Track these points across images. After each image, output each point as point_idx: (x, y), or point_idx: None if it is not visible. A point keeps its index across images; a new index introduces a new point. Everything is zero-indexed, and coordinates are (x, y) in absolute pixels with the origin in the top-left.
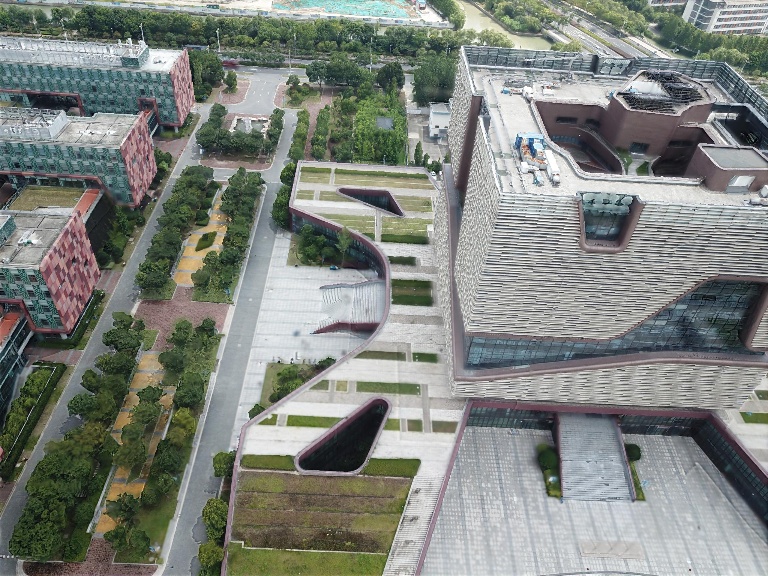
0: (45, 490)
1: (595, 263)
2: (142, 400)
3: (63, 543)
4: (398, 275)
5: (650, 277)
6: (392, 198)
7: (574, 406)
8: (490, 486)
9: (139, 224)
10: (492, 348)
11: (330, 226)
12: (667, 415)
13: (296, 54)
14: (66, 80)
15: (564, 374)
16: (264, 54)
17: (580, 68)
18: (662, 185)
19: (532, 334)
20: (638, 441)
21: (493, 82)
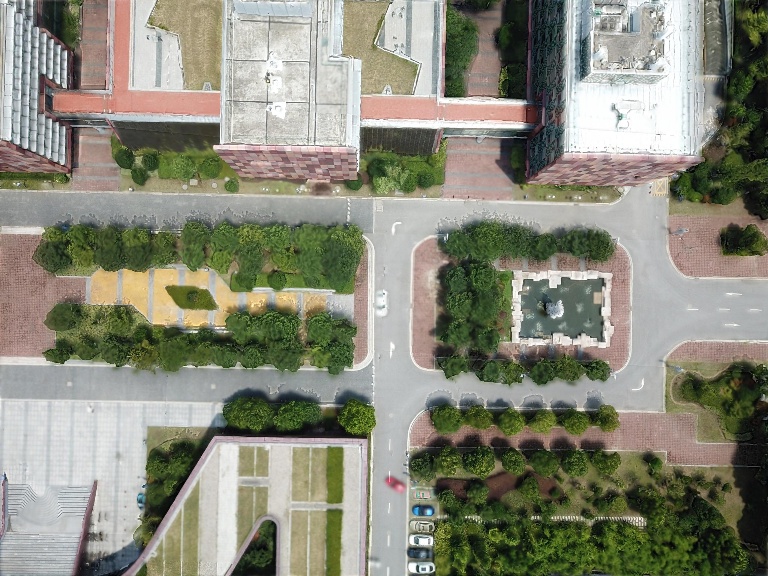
0: None
1: None
2: None
3: None
4: None
5: None
6: None
7: None
8: None
9: None
10: None
11: None
12: None
13: None
14: None
15: None
16: None
17: None
18: None
19: None
20: None
21: None
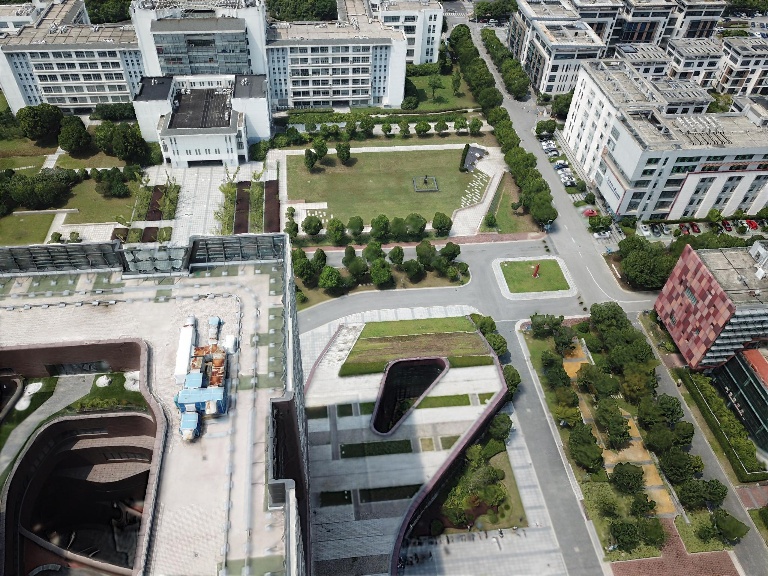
0: (627, 331)
1: None
2: None
3: (591, 322)
4: None
5: None
6: None
7: None
8: None
9: None
10: None
11: None
12: None
13: None
14: None
15: None
16: None
17: None
18: None
19: None
20: None
21: None
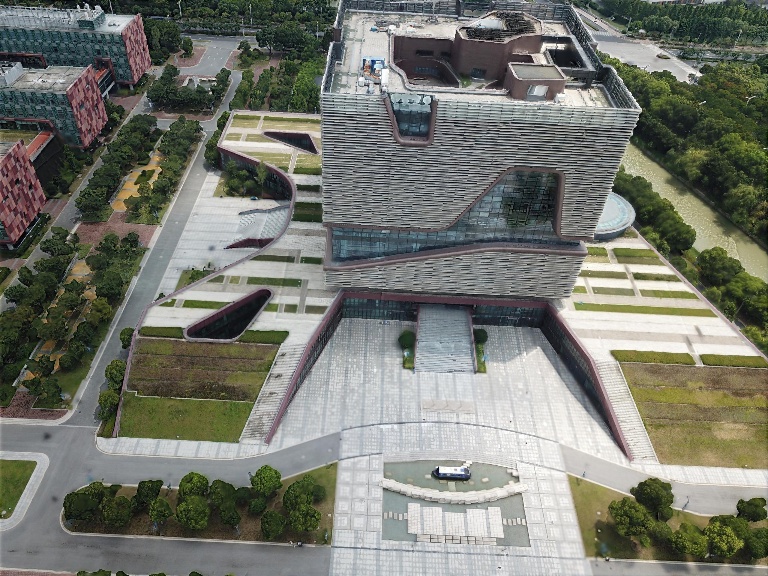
0: None
1: (412, 156)
2: (66, 290)
3: None
4: (302, 199)
5: (460, 169)
6: (310, 140)
7: (431, 296)
8: (355, 361)
9: (88, 163)
10: (351, 240)
11: (251, 162)
12: (512, 305)
13: (253, 24)
14: (30, 41)
15: (413, 263)
16: (222, 24)
17: (447, 12)
18: (475, 95)
19: (377, 224)
20: (491, 330)
21: (367, 23)
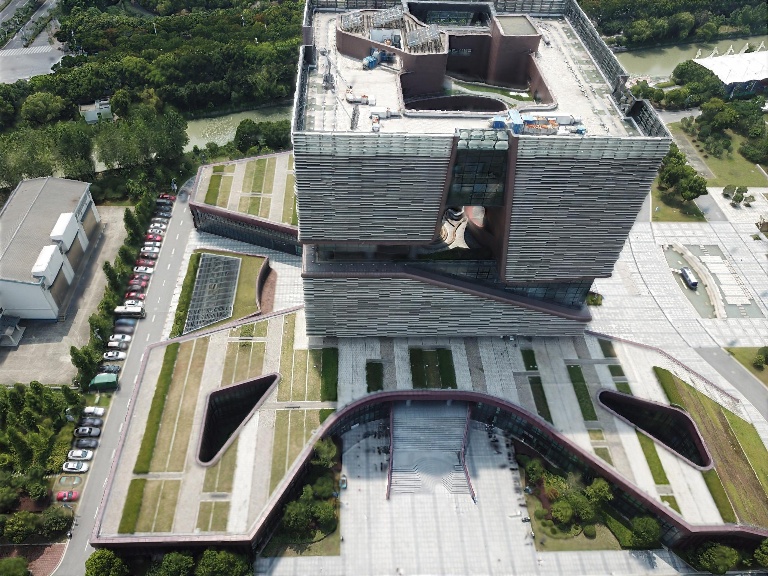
0: None
1: None
2: None
3: None
4: (403, 382)
5: None
6: (230, 388)
7: None
8: None
9: None
10: None
11: None
12: None
13: None
14: None
15: None
16: None
17: None
18: None
19: None
20: None
21: None
